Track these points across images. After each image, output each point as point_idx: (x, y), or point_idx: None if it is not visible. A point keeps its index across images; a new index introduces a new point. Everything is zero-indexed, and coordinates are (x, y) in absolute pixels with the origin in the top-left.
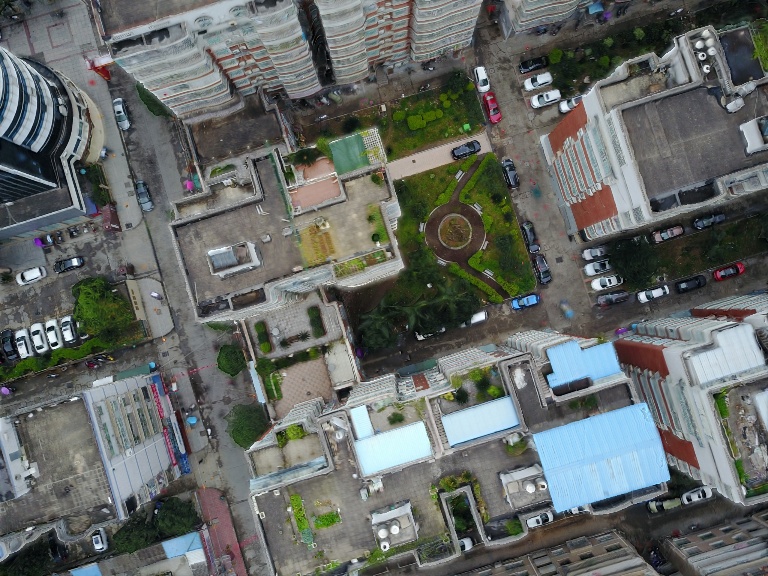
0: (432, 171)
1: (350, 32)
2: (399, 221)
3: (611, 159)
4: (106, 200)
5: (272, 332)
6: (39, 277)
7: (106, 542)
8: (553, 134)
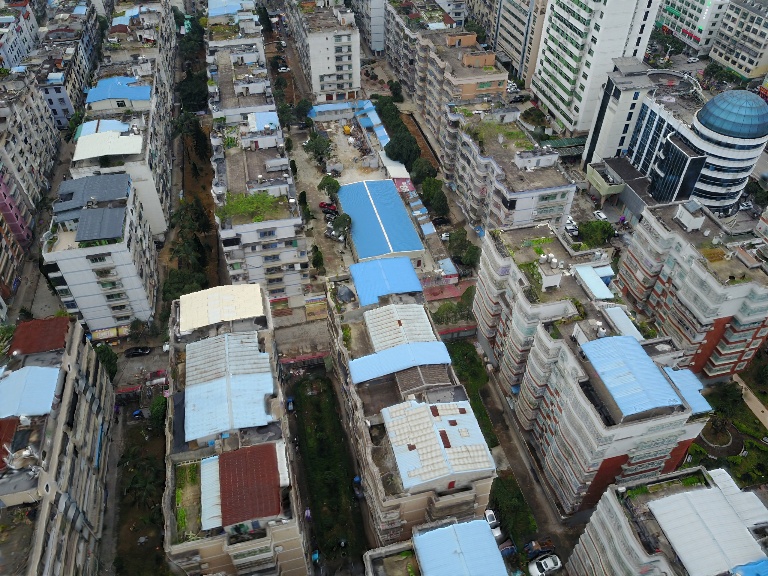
0: (761, 422)
1: None
2: (708, 398)
3: None
4: None
5: None
6: (601, 218)
7: (445, 239)
8: None
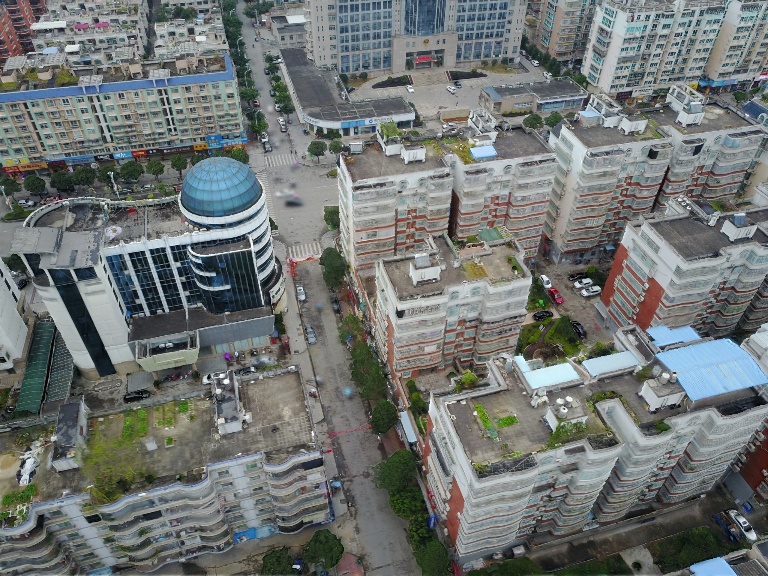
0: (521, 326)
1: (475, 213)
2: None
3: (650, 256)
4: (285, 331)
5: (420, 388)
6: None
7: None
8: (604, 292)
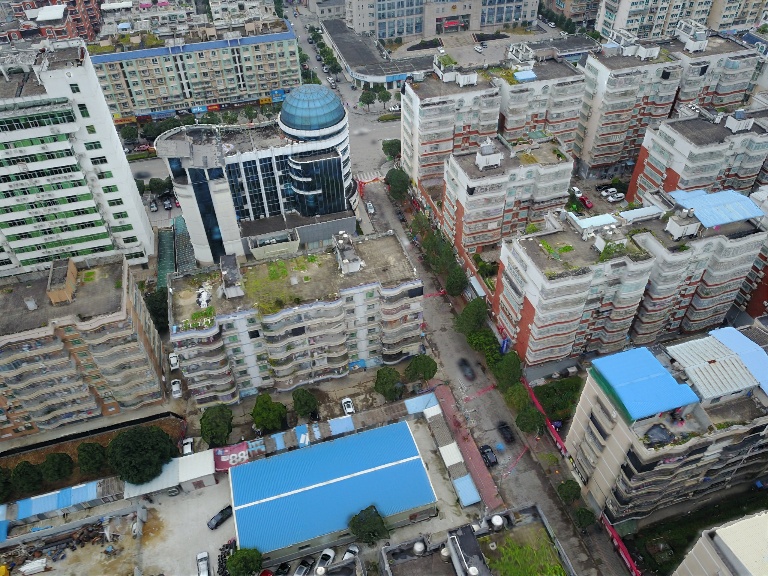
0: None
1: (518, 128)
2: None
3: None
4: None
5: (484, 260)
6: None
7: None
8: (628, 192)
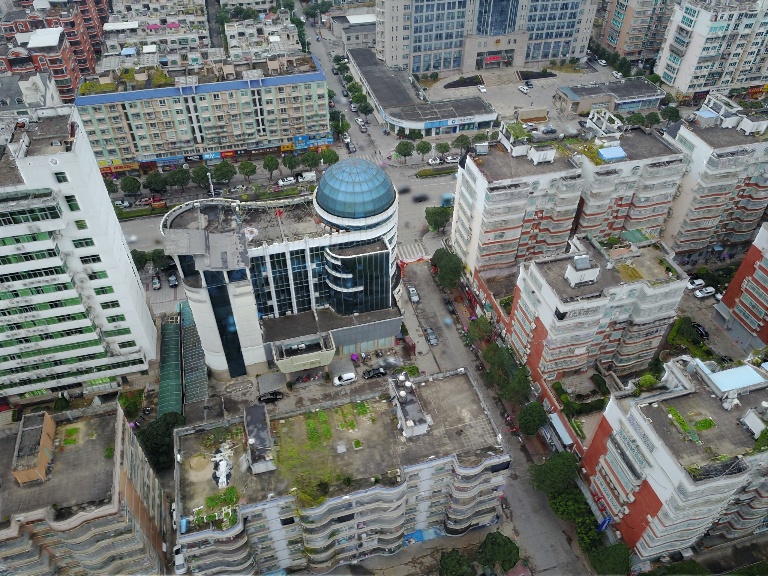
0: None
1: (599, 214)
2: None
3: None
4: None
5: (567, 390)
6: (353, 379)
7: None
8: (726, 293)
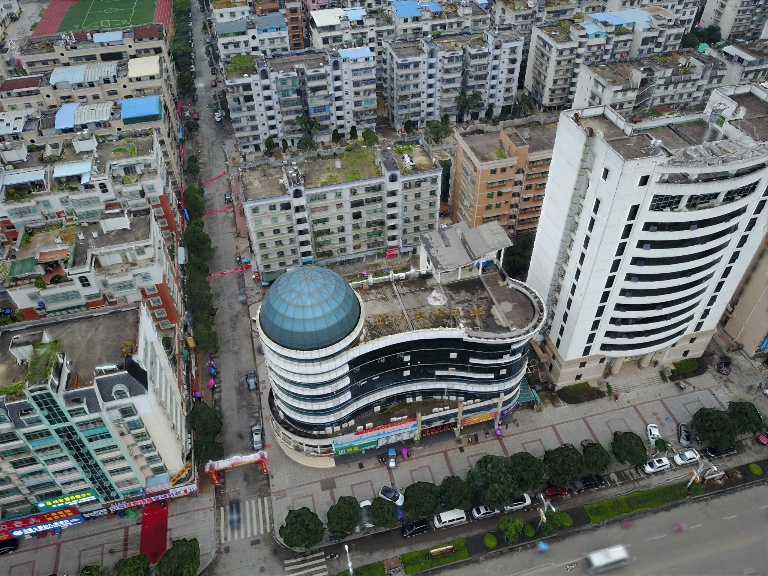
0: None
1: None
2: None
3: None
4: None
5: None
6: None
7: None
8: None
